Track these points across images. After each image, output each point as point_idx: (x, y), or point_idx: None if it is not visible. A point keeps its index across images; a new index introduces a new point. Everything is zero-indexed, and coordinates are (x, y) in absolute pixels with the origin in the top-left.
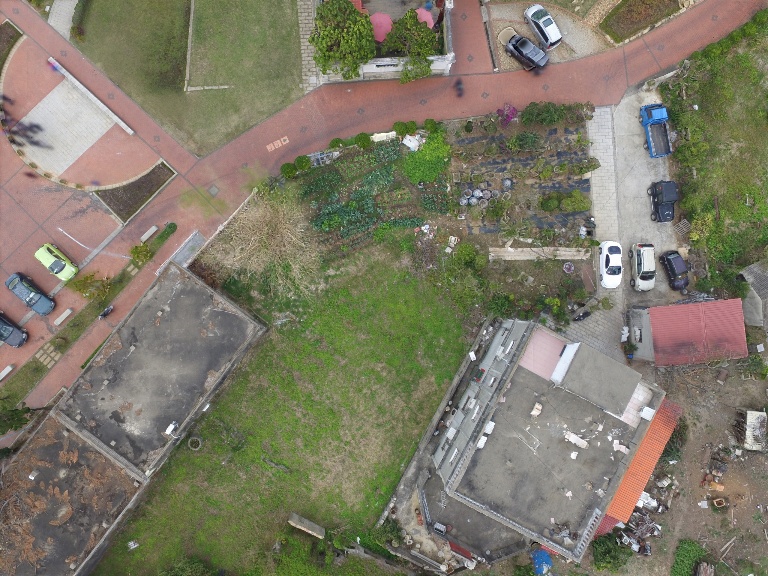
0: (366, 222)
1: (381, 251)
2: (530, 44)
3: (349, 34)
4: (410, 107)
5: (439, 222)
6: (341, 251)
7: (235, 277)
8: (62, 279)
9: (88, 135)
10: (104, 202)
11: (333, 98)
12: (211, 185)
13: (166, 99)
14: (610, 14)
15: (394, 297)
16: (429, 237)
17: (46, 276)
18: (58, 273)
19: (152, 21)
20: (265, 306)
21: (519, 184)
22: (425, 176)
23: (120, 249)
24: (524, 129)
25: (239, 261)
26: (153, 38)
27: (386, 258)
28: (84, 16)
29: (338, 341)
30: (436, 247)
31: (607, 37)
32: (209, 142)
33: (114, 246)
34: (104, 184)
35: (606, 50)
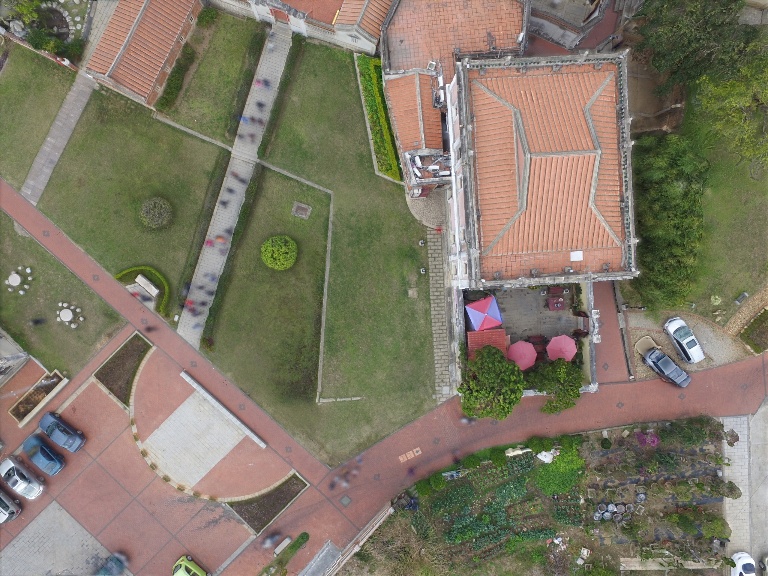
0: (498, 534)
1: (513, 561)
2: (672, 365)
3: (506, 402)
4: (544, 418)
5: (571, 533)
6: (473, 562)
7: None
8: None
9: (220, 446)
10: (237, 513)
11: None
12: (343, 495)
13: (297, 409)
14: (752, 325)
15: None
16: (561, 549)
17: None
18: None
19: (282, 329)
20: None
21: None
22: (558, 488)
23: (253, 558)
24: None
25: (373, 575)
26: (284, 347)
27: (517, 568)
28: (214, 326)
29: None
30: (568, 558)
31: (747, 347)
32: (341, 452)
33: (247, 555)
34: (237, 495)
35: (745, 358)
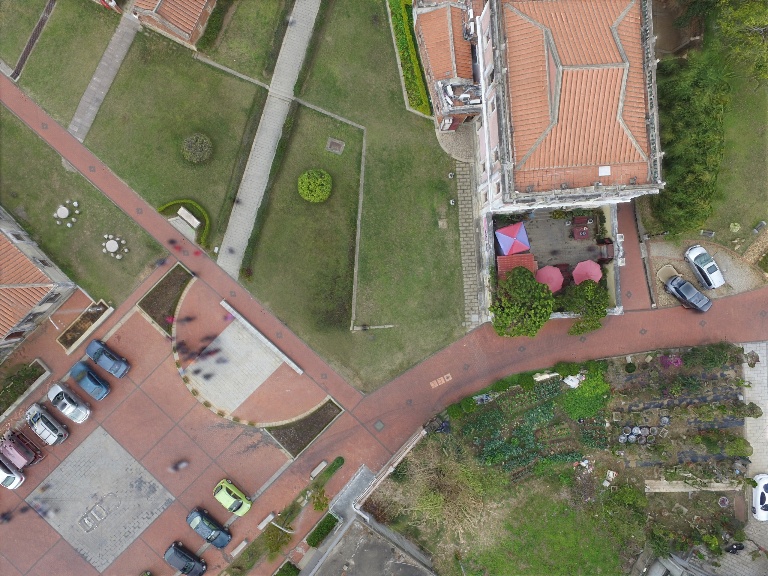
0: (527, 457)
1: (541, 484)
2: (694, 290)
3: (537, 316)
4: (570, 344)
5: (597, 456)
6: (502, 484)
7: (402, 512)
8: (239, 515)
9: (258, 373)
10: (275, 438)
11: (495, 336)
12: (376, 420)
13: (332, 337)
14: None
15: (553, 529)
16: (588, 471)
17: (221, 508)
18: (236, 511)
19: (317, 260)
20: (431, 539)
21: (675, 419)
22: (584, 412)
23: (290, 482)
24: (681, 365)
25: (406, 497)
26: (319, 277)
27: (545, 490)
28: (252, 257)
29: (500, 570)
30: (594, 481)
31: (765, 274)
32: (374, 379)
33: (284, 479)
34: (274, 420)
35: (763, 286)
